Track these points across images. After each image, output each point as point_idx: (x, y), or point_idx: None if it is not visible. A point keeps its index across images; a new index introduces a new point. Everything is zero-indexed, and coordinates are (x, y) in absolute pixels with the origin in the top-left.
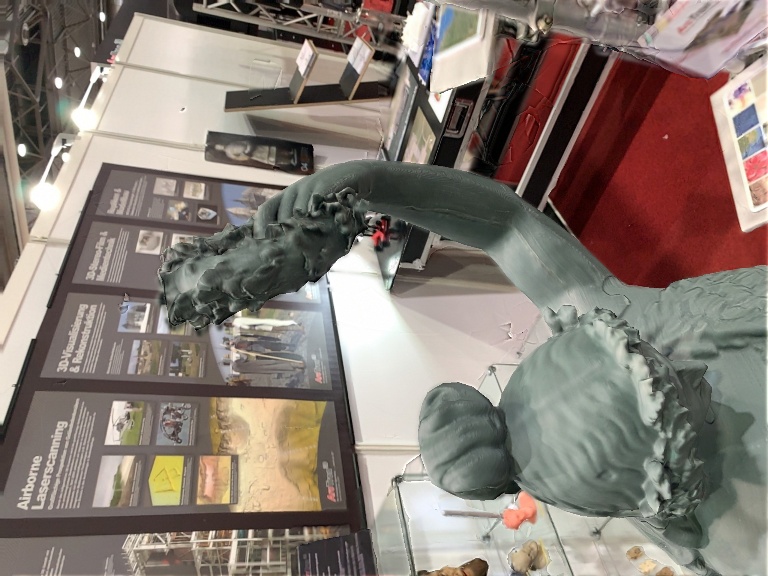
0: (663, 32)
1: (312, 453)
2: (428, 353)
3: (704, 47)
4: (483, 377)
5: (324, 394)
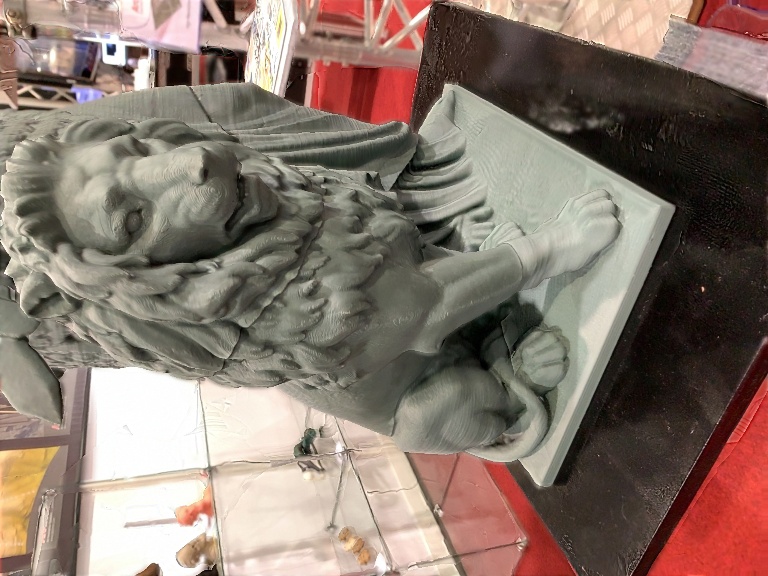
0: (125, 14)
1: (29, 499)
2: (190, 386)
3: (170, 24)
4: (196, 389)
5: (58, 439)
